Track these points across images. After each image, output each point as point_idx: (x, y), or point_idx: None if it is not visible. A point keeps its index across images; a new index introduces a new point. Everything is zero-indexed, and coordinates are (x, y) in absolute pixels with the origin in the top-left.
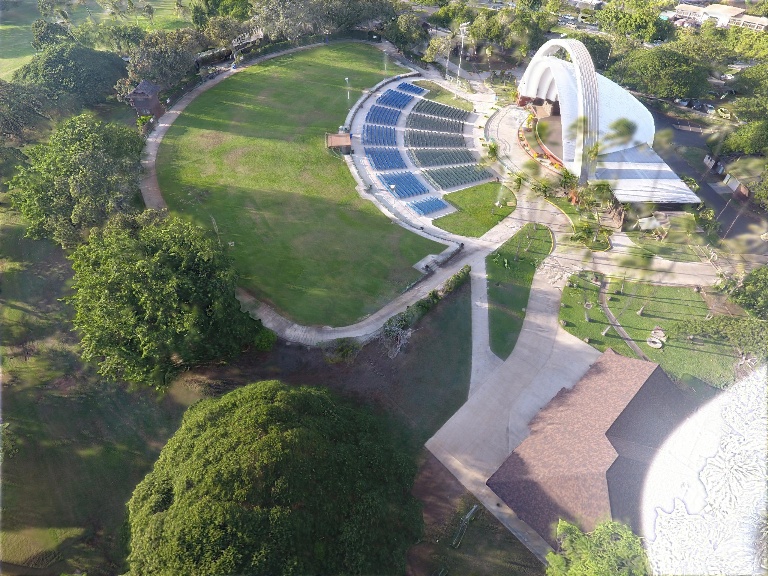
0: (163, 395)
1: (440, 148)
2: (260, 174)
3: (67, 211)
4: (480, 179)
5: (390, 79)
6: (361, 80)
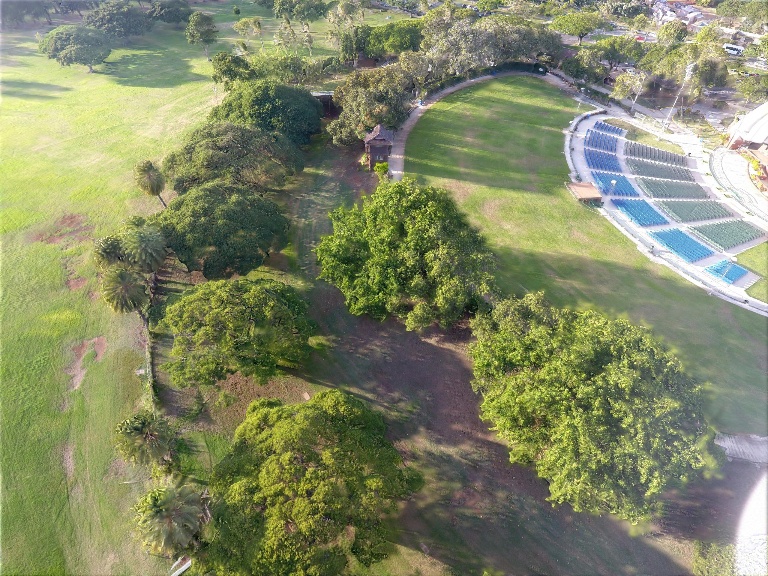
0: (603, 521)
1: (684, 199)
2: (532, 232)
3: (426, 292)
4: (754, 238)
5: (581, 117)
6: (553, 118)
